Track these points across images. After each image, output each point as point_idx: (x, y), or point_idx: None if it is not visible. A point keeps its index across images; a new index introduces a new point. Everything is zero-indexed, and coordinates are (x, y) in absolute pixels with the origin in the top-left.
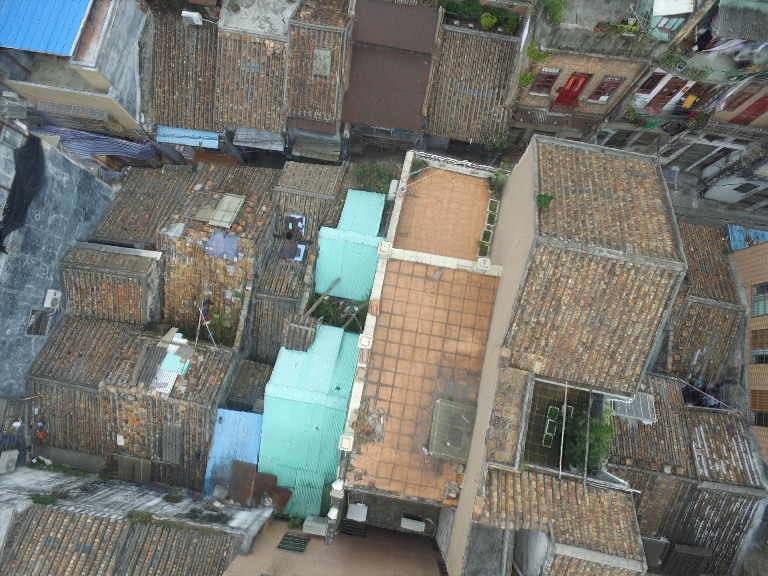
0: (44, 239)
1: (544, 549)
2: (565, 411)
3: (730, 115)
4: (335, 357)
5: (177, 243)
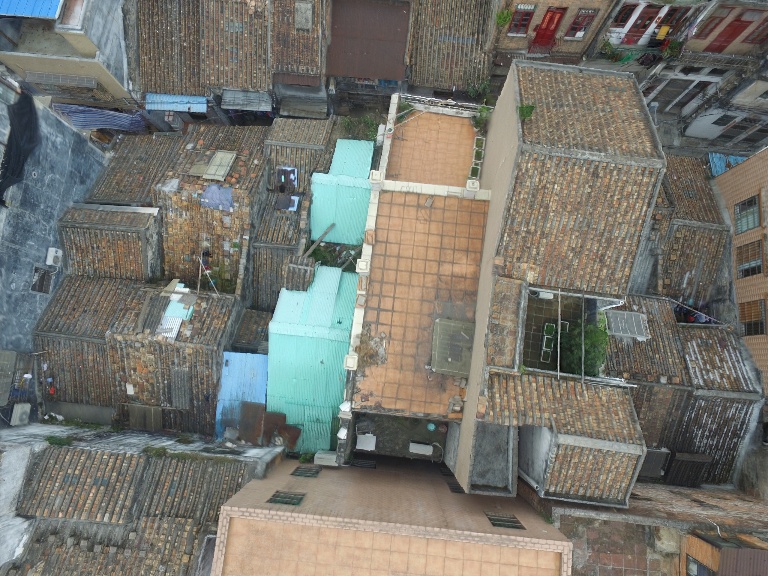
0: (42, 198)
1: (548, 443)
2: None
3: (703, 44)
4: (335, 294)
5: (173, 198)
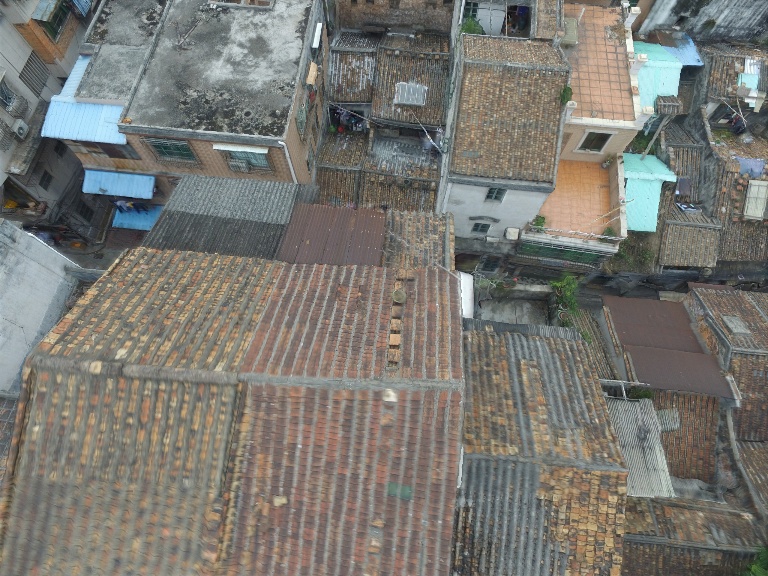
0: None
1: None
2: None
3: None
4: None
5: None
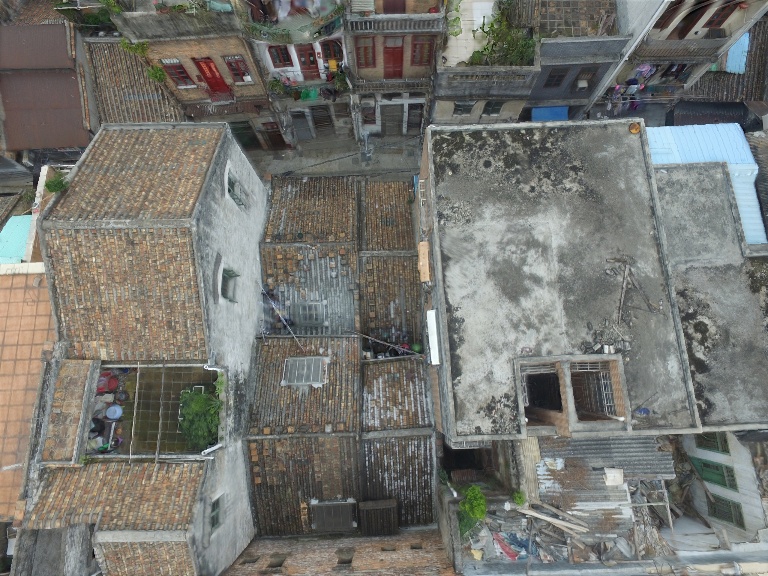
0: None
1: None
2: (136, 392)
3: (378, 72)
4: None
5: None
